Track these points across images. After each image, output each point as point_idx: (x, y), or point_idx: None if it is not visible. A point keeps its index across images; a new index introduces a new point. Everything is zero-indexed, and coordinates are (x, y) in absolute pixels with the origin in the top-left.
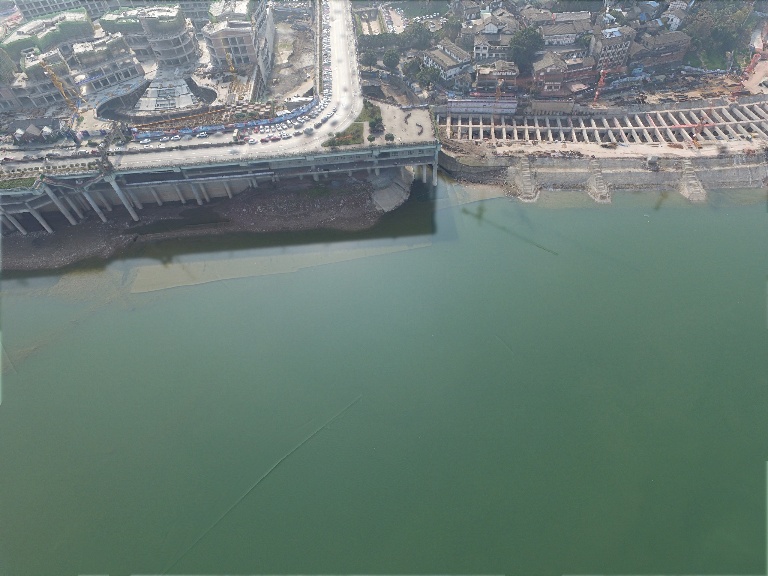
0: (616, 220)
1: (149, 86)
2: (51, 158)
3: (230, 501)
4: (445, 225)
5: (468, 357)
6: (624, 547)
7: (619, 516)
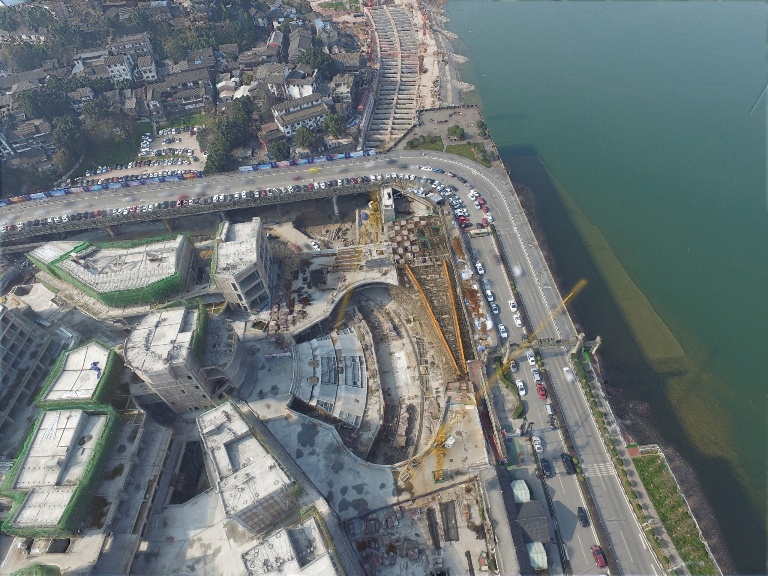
0: (492, 85)
1: (306, 401)
2: (578, 460)
3: None
4: (513, 150)
5: (669, 114)
6: (719, 100)
7: (706, 99)
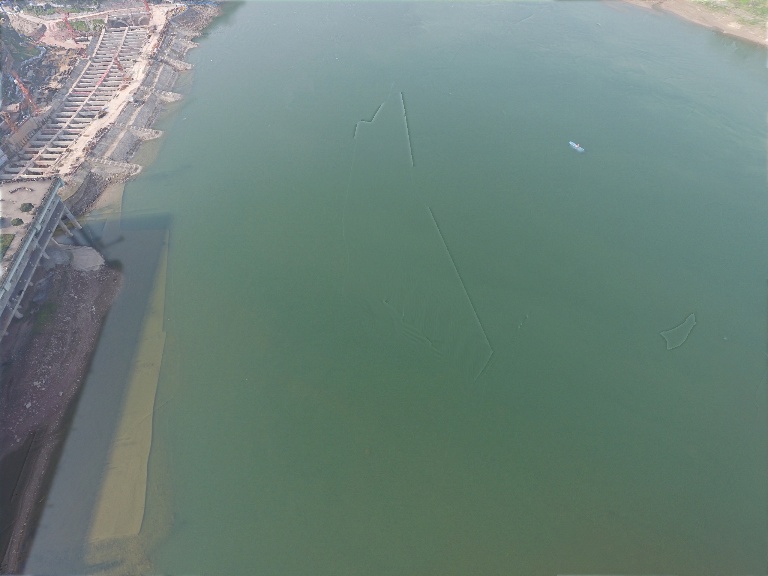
0: (184, 131)
1: None
2: None
3: (428, 247)
4: (145, 221)
5: (308, 183)
6: None
7: None
